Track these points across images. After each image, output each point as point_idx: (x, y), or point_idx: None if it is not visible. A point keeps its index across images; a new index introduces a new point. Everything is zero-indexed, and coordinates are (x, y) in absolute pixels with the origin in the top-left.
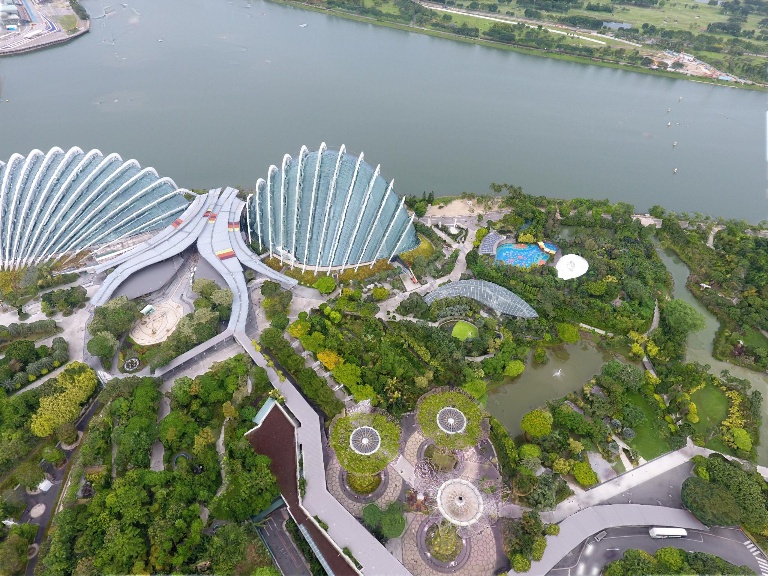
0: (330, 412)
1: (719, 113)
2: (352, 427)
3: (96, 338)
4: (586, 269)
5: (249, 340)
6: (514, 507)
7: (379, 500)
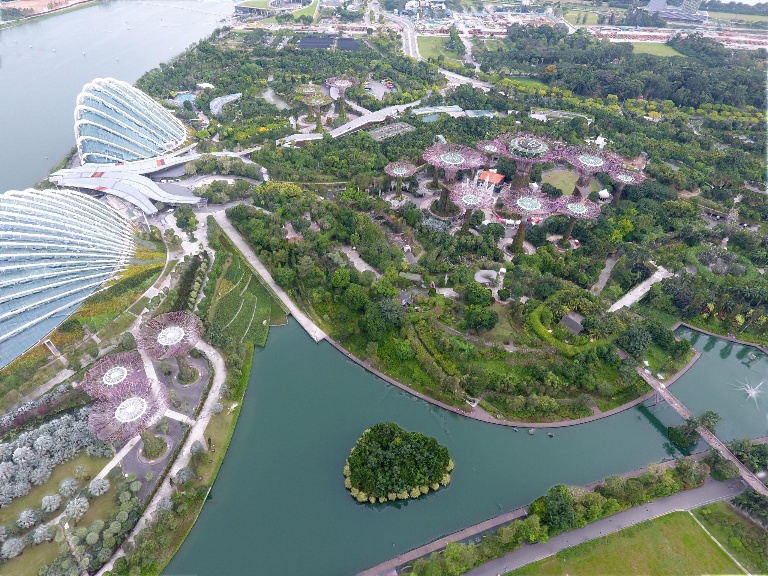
0: (292, 131)
1: (49, 38)
2: (312, 103)
3: (239, 181)
4: (208, 84)
5: (243, 151)
6: (330, 110)
7: (329, 130)
